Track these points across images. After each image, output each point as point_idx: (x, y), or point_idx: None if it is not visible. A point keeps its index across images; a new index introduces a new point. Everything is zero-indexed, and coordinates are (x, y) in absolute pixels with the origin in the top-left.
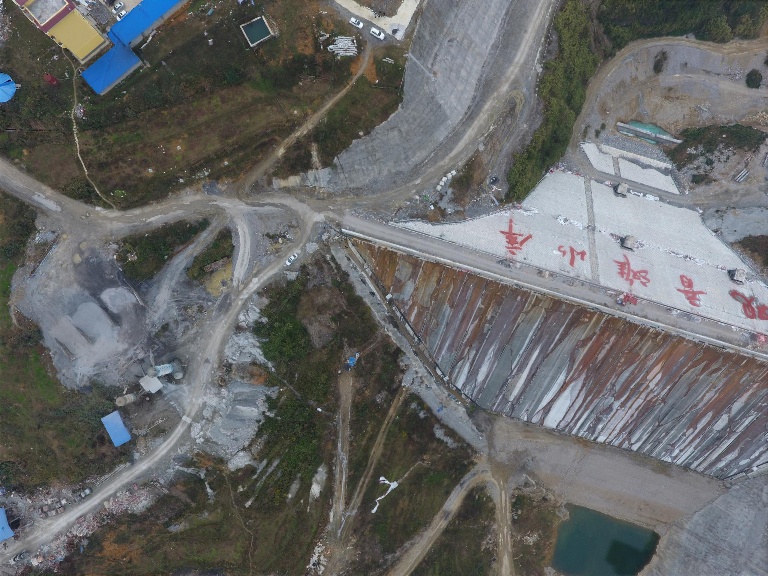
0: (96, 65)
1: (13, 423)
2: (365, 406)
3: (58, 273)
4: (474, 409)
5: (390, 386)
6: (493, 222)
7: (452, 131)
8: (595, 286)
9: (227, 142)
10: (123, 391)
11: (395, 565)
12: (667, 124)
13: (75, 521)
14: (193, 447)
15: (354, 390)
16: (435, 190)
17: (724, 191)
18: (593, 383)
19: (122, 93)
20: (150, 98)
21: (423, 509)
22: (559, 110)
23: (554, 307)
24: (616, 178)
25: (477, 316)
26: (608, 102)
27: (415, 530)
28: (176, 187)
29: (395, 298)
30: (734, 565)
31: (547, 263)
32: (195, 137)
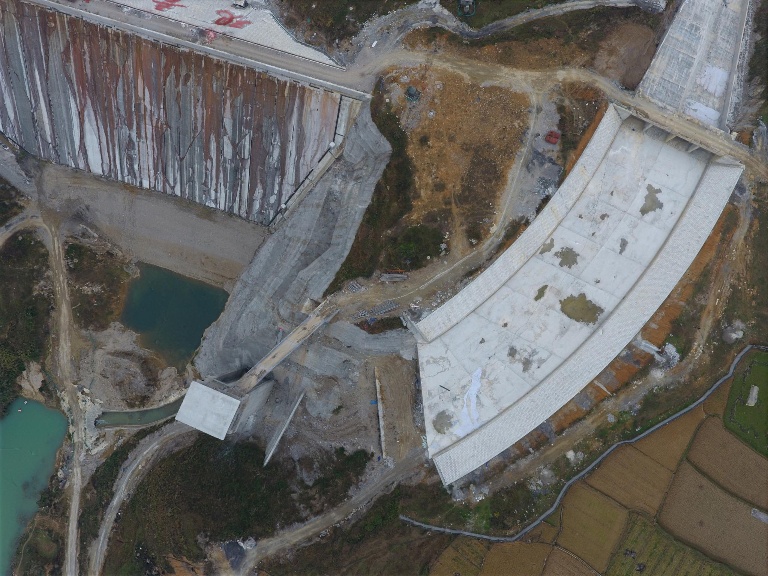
0: None
1: None
2: None
3: None
4: (24, 155)
5: None
6: None
7: None
8: None
9: None
10: None
11: None
12: None
13: None
14: None
15: None
16: None
17: None
18: (101, 109)
19: None
20: None
21: None
22: None
23: (19, 11)
24: None
25: None
26: None
27: None
28: None
29: None
30: (249, 294)
31: None
32: None
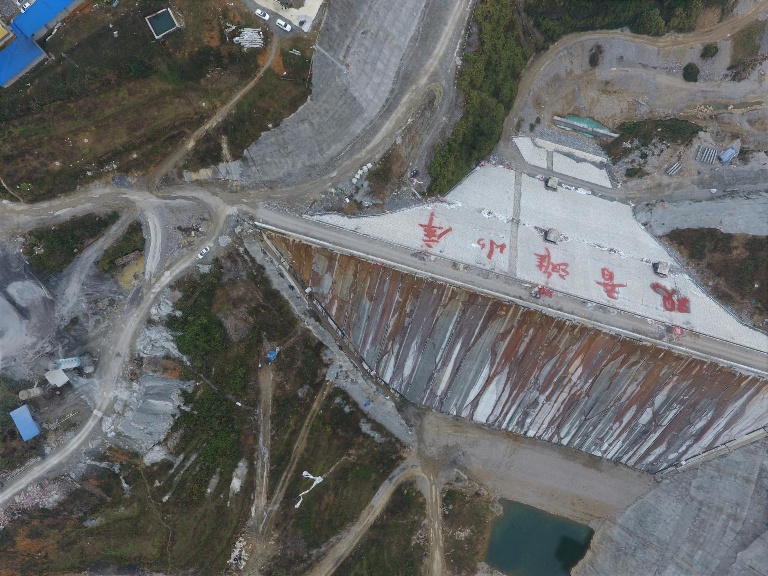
0: None
1: None
2: (286, 400)
3: None
4: (403, 404)
5: (313, 380)
6: (413, 215)
7: (369, 124)
8: (510, 279)
9: (135, 135)
10: (34, 385)
11: (321, 560)
12: (605, 118)
13: None
14: (105, 441)
15: (274, 384)
16: (351, 183)
17: (656, 184)
18: (517, 377)
19: (26, 85)
20: (54, 90)
21: (350, 504)
22: (480, 103)
23: (470, 300)
24: (548, 172)
25: (396, 309)
26: (543, 96)
27: (341, 525)
28: (84, 180)
29: (315, 292)
30: (661, 559)
31: (463, 256)
32: (102, 130)
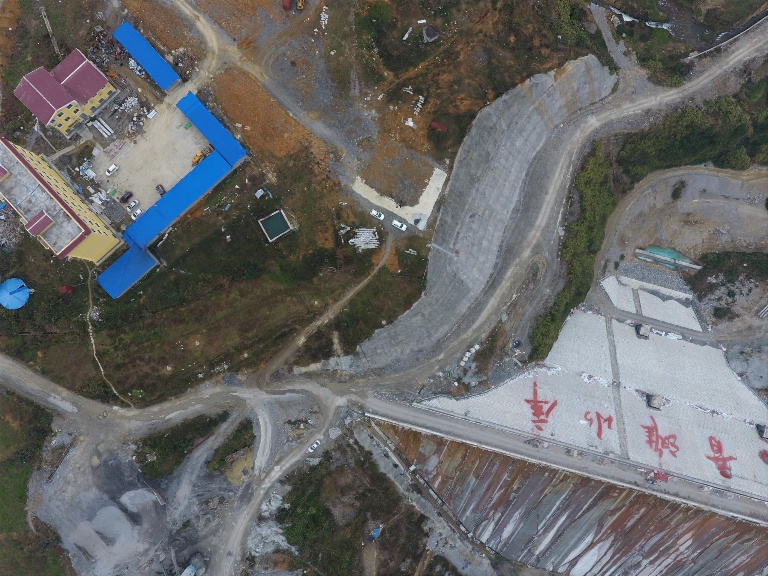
0: (112, 269)
1: None
2: None
3: (76, 477)
4: (499, 560)
5: (414, 552)
6: (517, 388)
7: (474, 301)
8: (625, 464)
9: (247, 336)
10: None
11: None
12: (686, 249)
13: None
14: None
15: (378, 562)
16: (459, 365)
17: (747, 327)
18: (621, 544)
19: (139, 294)
20: (167, 299)
21: None
22: (582, 270)
23: (583, 483)
24: (637, 316)
25: (503, 486)
26: (627, 233)
27: None
28: (195, 383)
29: (419, 468)
30: None
31: (575, 438)
32: (214, 332)
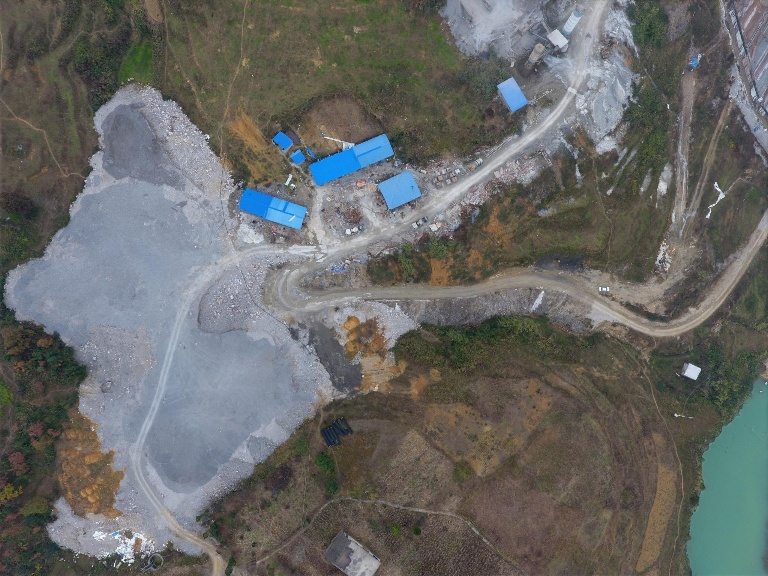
0: None
1: (411, 93)
2: (704, 108)
3: None
4: None
5: None
6: None
7: None
8: None
9: None
10: (510, 65)
11: (722, 276)
12: None
13: (467, 191)
14: (576, 119)
15: (697, 90)
16: None
17: None
18: None
19: None
20: None
21: (743, 225)
22: None
23: None
24: None
25: None
26: None
27: (739, 243)
28: None
29: None
30: None
31: None
32: None
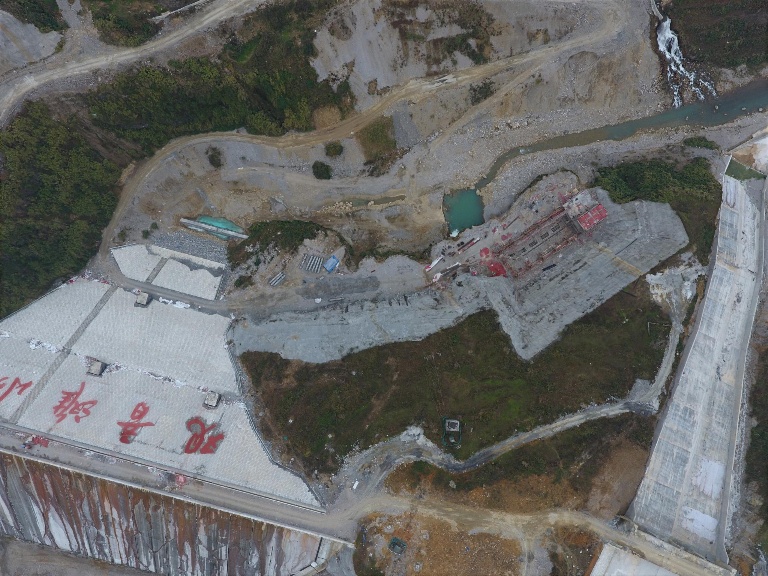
0: None
1: None
2: None
3: None
4: None
5: None
6: None
7: None
8: (3, 428)
9: None
10: None
11: None
12: (237, 218)
13: None
14: None
15: None
16: None
17: (259, 295)
18: (66, 514)
19: None
20: None
21: None
22: (10, 233)
23: None
24: (145, 285)
25: None
26: (157, 201)
27: None
28: None
29: None
30: None
31: None
32: None
